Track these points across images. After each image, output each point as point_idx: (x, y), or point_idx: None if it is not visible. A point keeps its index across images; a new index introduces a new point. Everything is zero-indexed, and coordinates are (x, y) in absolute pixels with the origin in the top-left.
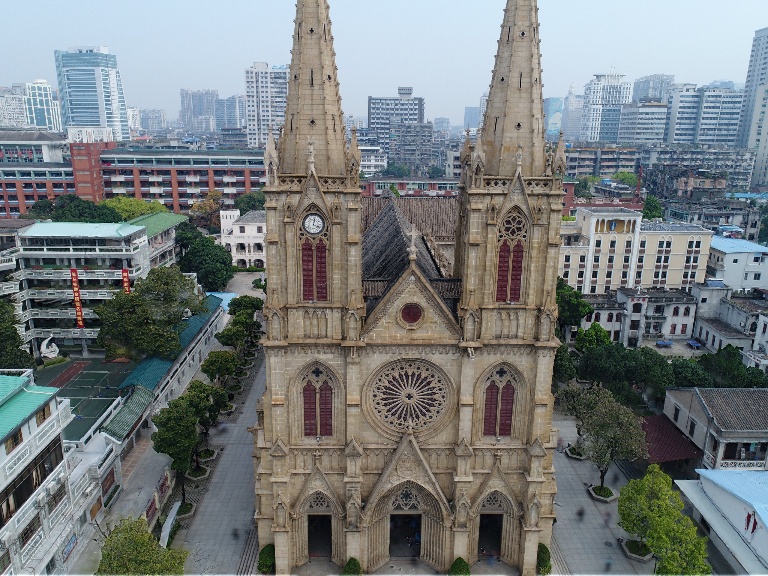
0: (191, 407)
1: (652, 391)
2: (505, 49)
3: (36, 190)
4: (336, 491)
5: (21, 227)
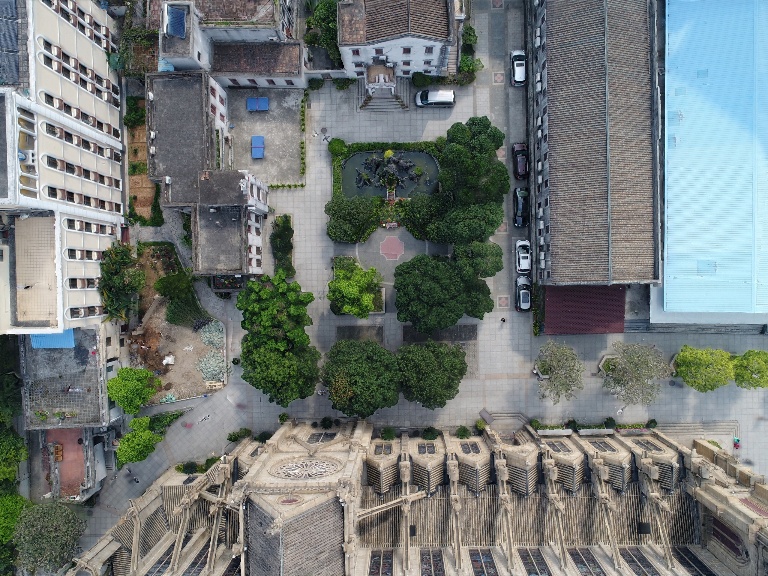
0: None
1: None
2: None
3: None
4: None
5: None
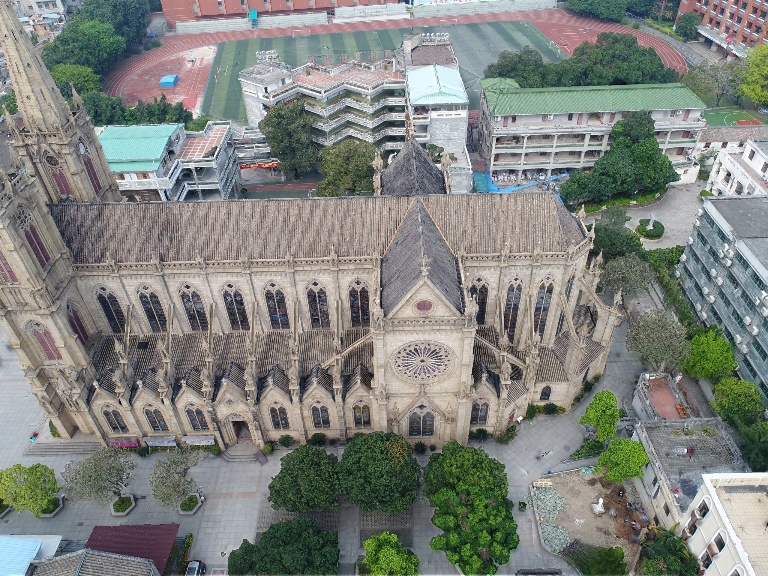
0: None
1: None
2: None
3: (763, 4)
4: None
5: (416, 65)
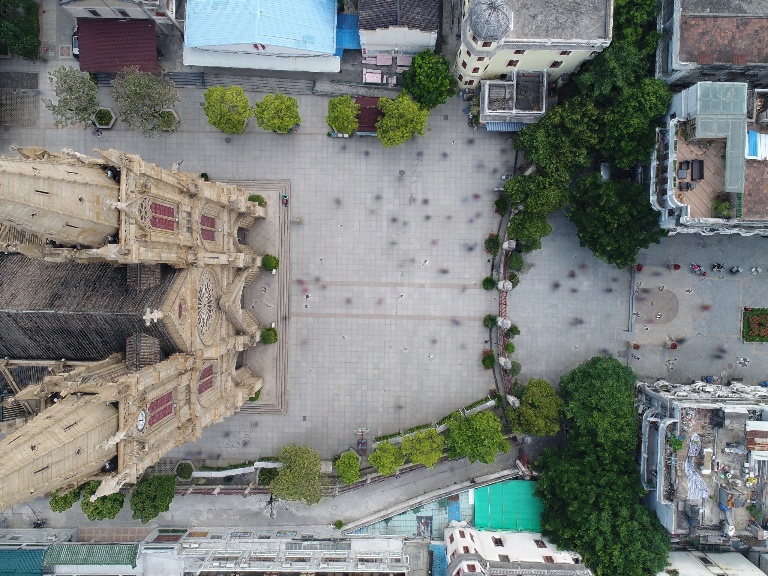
0: (107, 497)
1: (24, 3)
2: (2, 209)
3: None
4: (233, 354)
5: None
